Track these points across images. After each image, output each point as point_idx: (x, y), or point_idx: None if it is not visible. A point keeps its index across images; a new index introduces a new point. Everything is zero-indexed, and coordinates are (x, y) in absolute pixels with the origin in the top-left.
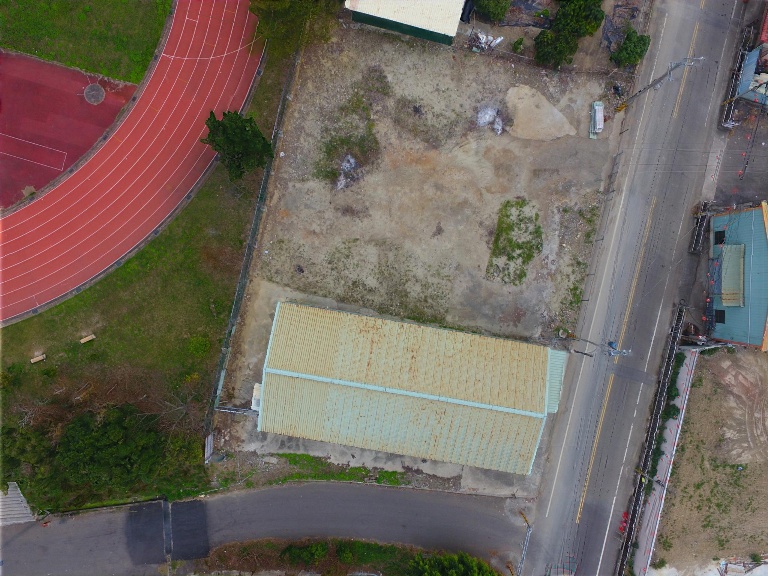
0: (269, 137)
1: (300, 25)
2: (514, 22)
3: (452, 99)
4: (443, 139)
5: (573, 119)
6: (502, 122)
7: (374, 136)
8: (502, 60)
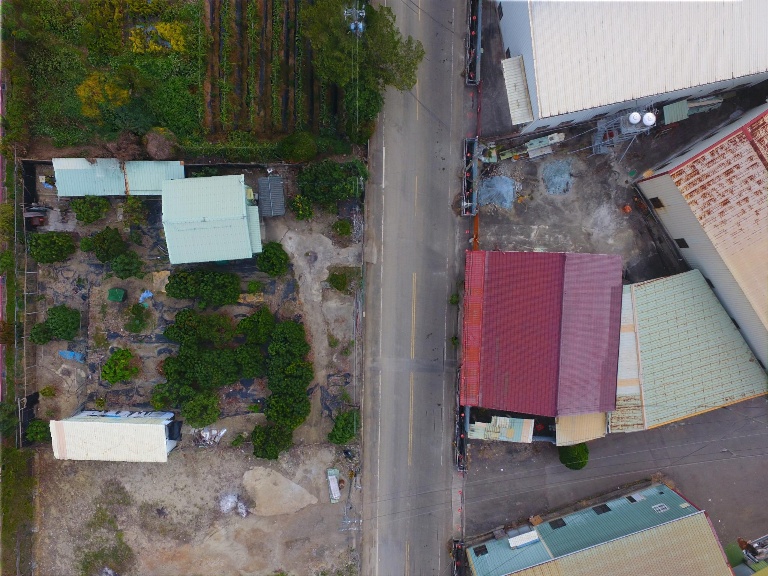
0: (24, 571)
1: (29, 461)
2: (233, 413)
3: (192, 495)
4: (192, 533)
5: (312, 488)
6: (244, 506)
7: (126, 544)
8: (231, 448)
